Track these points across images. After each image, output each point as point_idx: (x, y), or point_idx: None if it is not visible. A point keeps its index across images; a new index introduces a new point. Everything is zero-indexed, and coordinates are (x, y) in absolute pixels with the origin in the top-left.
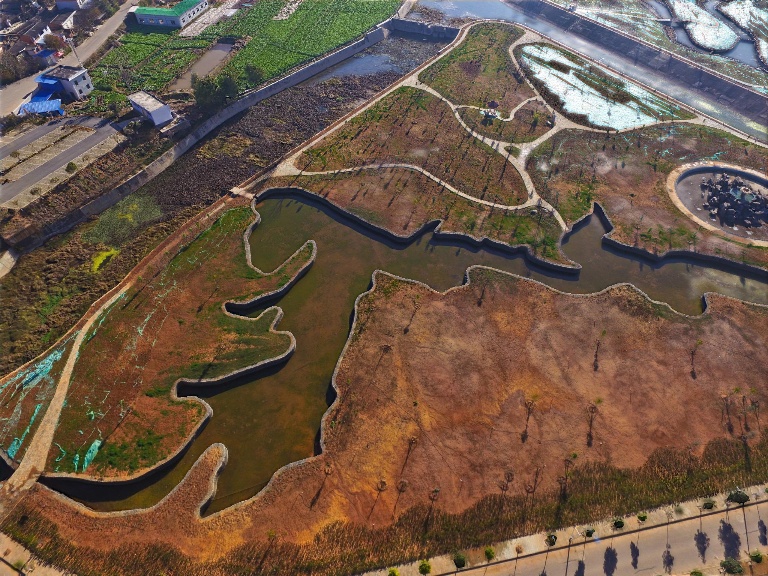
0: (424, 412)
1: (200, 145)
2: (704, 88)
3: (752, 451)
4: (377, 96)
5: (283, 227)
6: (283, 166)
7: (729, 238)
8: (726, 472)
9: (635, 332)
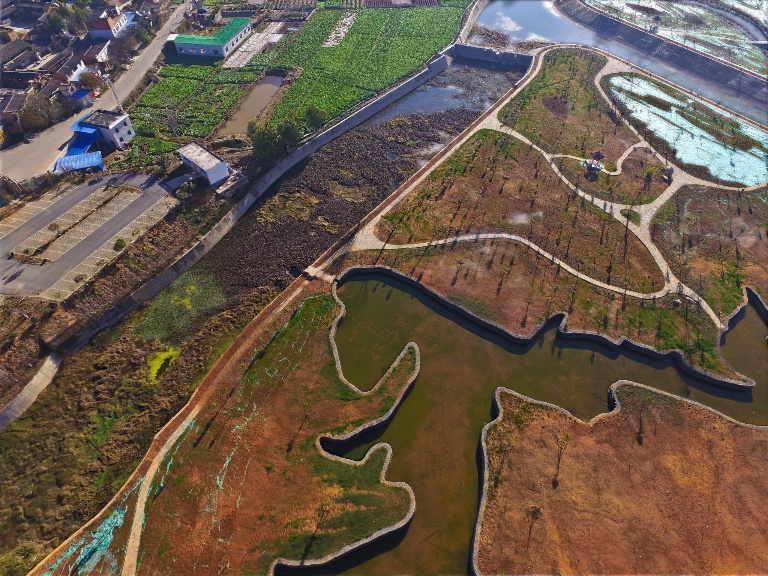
0: None
1: (260, 205)
2: None
3: None
4: (455, 142)
5: (373, 321)
6: (362, 236)
7: None
8: None
9: None
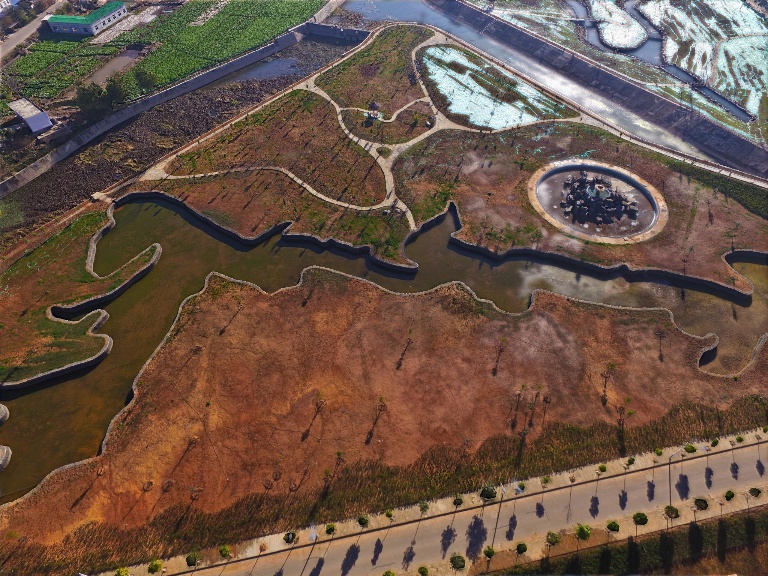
0: (214, 412)
1: (81, 151)
2: (600, 87)
3: (527, 447)
4: (268, 100)
5: (135, 231)
6: (152, 170)
7: (574, 235)
8: (495, 468)
9: (450, 330)
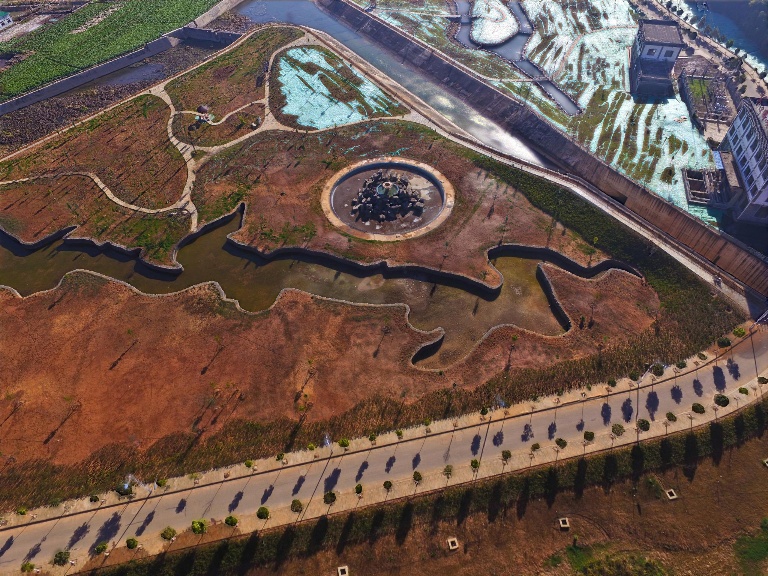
0: None
1: None
2: (450, 83)
3: (199, 444)
4: (111, 105)
5: None
6: None
7: (349, 233)
8: (157, 465)
9: (181, 330)
